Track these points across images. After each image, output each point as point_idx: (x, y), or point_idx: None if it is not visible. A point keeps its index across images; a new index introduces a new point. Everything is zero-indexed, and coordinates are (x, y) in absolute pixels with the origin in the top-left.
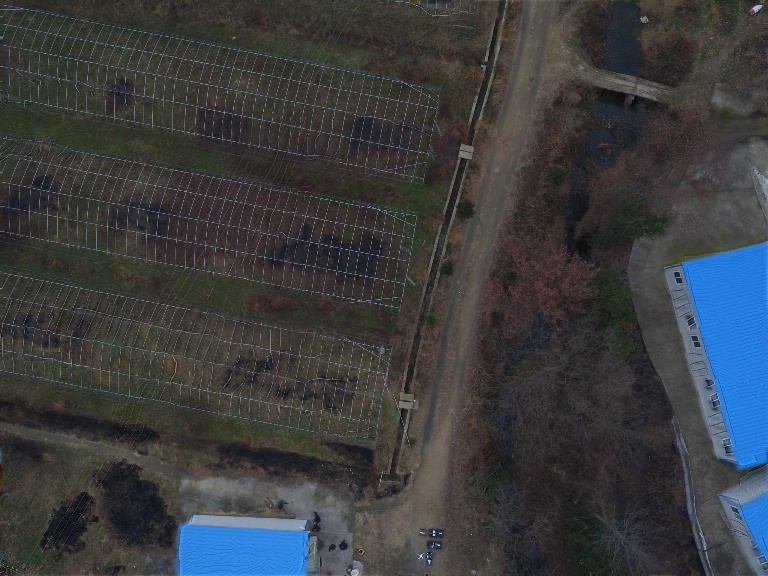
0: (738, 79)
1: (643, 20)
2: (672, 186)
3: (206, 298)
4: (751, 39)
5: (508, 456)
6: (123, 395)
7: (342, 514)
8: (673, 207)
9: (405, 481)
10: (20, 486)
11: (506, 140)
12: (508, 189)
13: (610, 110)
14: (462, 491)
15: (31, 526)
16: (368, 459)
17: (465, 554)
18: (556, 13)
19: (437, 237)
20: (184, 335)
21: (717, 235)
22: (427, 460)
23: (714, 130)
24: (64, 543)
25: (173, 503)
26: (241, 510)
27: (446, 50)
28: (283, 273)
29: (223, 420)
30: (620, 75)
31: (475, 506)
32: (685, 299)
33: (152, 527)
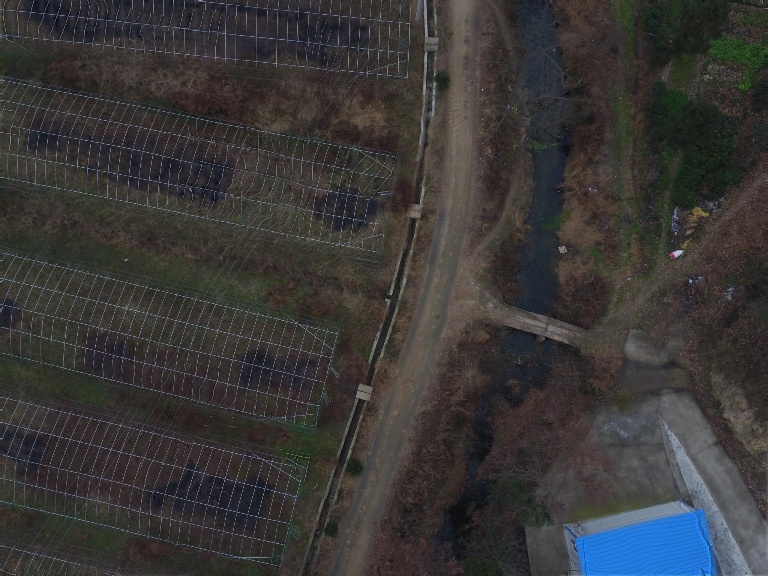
0: (653, 327)
1: (561, 250)
2: (578, 437)
3: None
4: (669, 285)
5: None
6: None
7: None
8: (578, 460)
9: None
10: None
11: (407, 381)
12: (406, 434)
13: (521, 346)
14: None
15: None
16: None
17: None
18: (467, 246)
19: (330, 481)
20: None
21: (622, 492)
22: None
23: (625, 380)
24: None
25: None
26: None
27: (349, 282)
28: (160, 527)
29: None
30: (531, 314)
31: None
32: (579, 575)
33: None
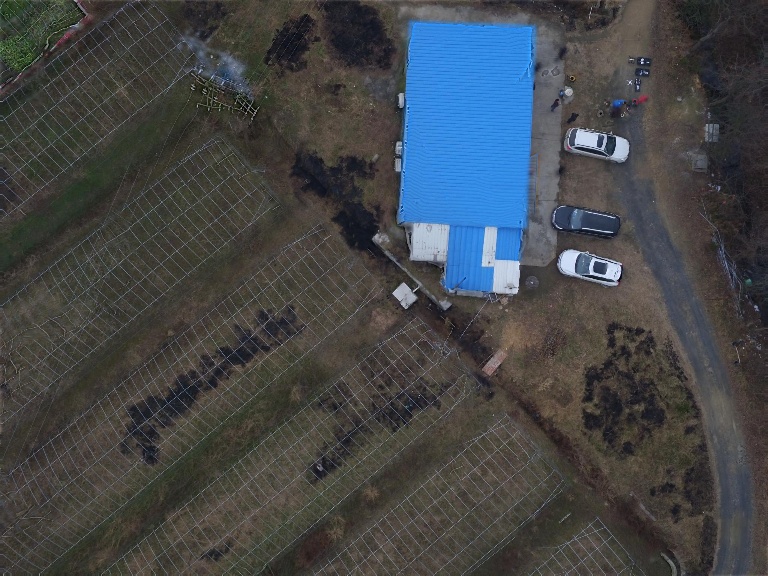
0: None
1: None
2: None
3: None
4: None
5: (704, 9)
6: None
7: (554, 43)
8: None
9: (614, 15)
10: (245, 6)
11: None
12: None
13: None
14: (669, 23)
15: (255, 43)
16: None
17: (671, 82)
18: None
19: None
20: None
21: None
22: None
23: None
24: (287, 60)
25: (393, 27)
26: None
27: None
28: None
29: None
30: None
31: (681, 38)
32: None
33: (372, 49)
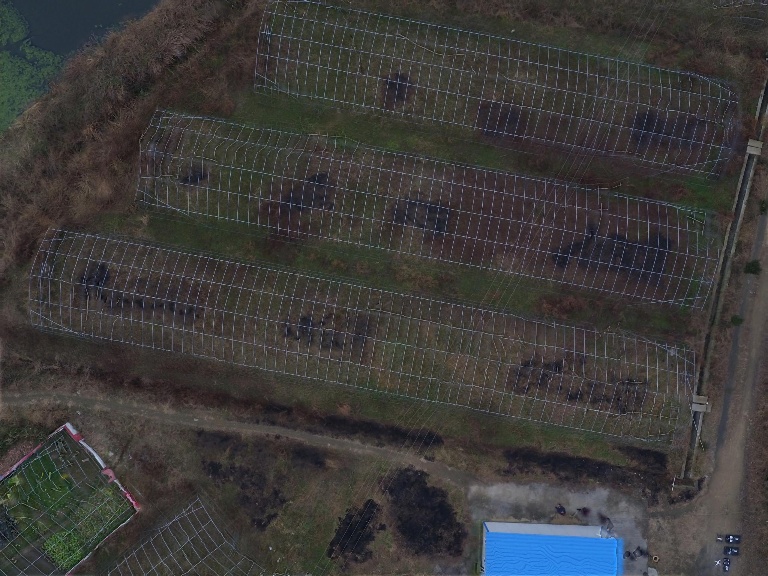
0: None
1: None
2: None
3: (640, 300)
4: None
5: None
6: (420, 399)
7: (636, 520)
8: None
9: (699, 486)
10: (304, 494)
11: None
12: None
13: None
14: (759, 496)
15: (317, 535)
16: (661, 463)
17: (762, 560)
18: None
19: (726, 235)
20: (486, 337)
21: None
22: (722, 464)
23: None
24: (351, 552)
25: (462, 510)
26: (532, 517)
27: (731, 42)
28: (586, 272)
29: (520, 424)
30: None
31: None
32: None
33: (441, 535)
